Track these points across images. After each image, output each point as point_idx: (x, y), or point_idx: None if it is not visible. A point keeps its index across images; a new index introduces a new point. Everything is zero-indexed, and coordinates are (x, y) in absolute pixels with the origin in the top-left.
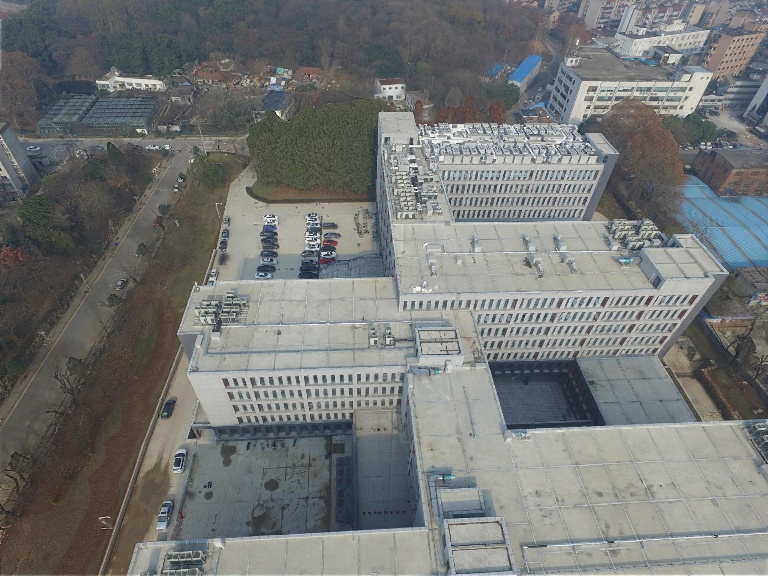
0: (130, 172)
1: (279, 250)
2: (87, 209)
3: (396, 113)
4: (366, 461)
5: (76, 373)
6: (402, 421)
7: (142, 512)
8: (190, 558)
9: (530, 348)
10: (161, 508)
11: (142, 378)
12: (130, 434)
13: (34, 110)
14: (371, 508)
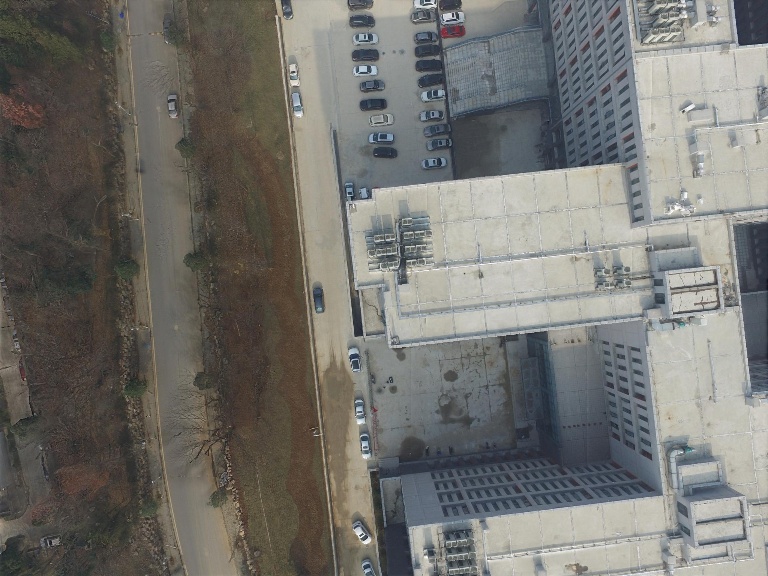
0: None
1: (374, 10)
2: None
3: None
4: (562, 377)
5: (198, 268)
6: (598, 331)
7: (337, 408)
8: None
9: (754, 220)
10: (356, 408)
11: (276, 268)
12: (295, 338)
13: None
14: (570, 422)
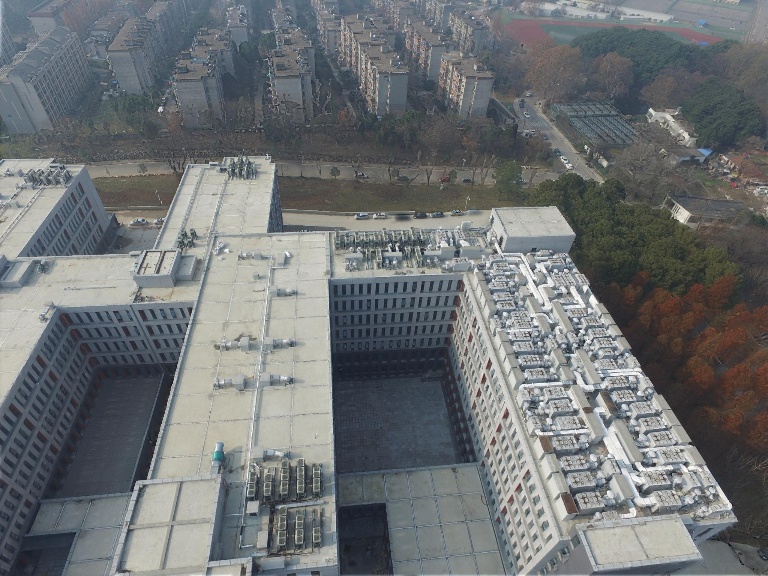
0: (517, 157)
1: None
2: (423, 136)
3: (562, 221)
4: None
5: None
6: None
7: None
8: (59, 175)
9: None
10: None
11: None
12: None
13: (563, 94)
14: None
